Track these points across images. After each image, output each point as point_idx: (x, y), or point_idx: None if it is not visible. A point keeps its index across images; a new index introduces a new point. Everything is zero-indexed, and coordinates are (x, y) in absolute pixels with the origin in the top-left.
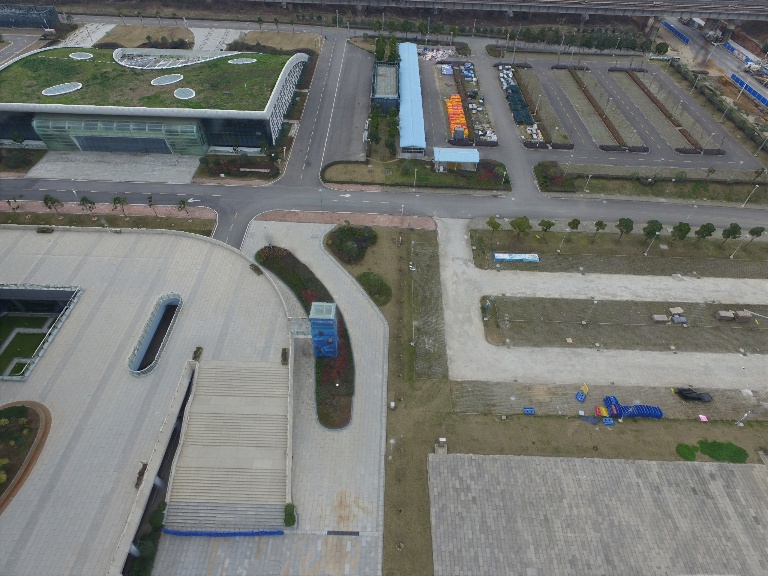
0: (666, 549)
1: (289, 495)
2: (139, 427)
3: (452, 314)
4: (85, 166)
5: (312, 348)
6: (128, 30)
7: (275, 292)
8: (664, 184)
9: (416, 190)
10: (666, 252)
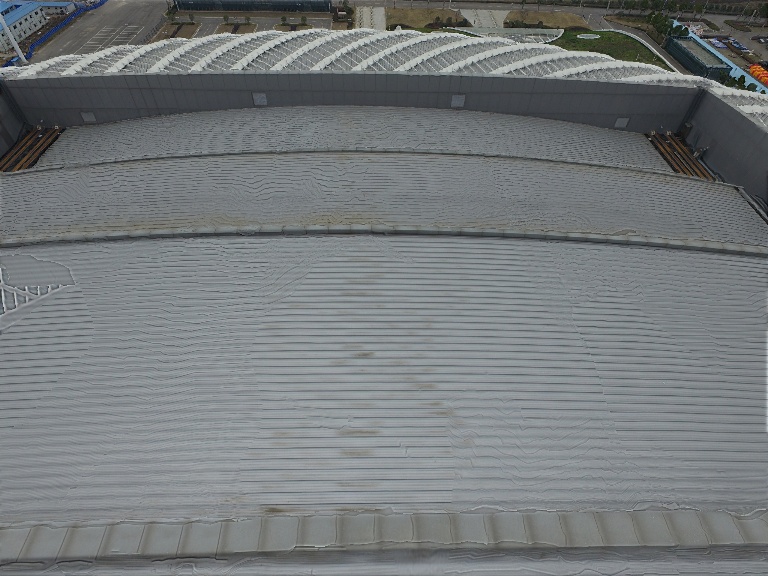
0: None
1: None
2: None
3: None
4: None
5: None
6: (402, 12)
7: None
8: None
9: None
10: None
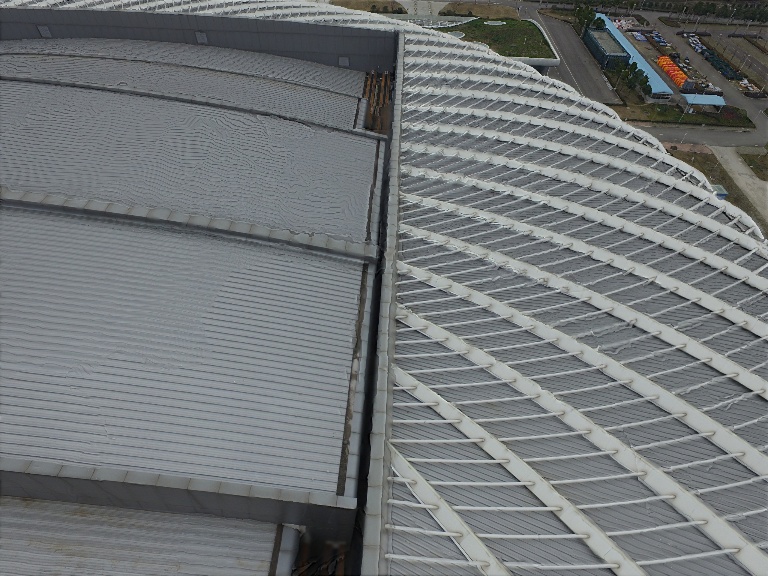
0: None
1: None
2: None
3: (764, 209)
4: None
5: None
6: (345, 1)
7: None
8: None
9: (679, 126)
10: None
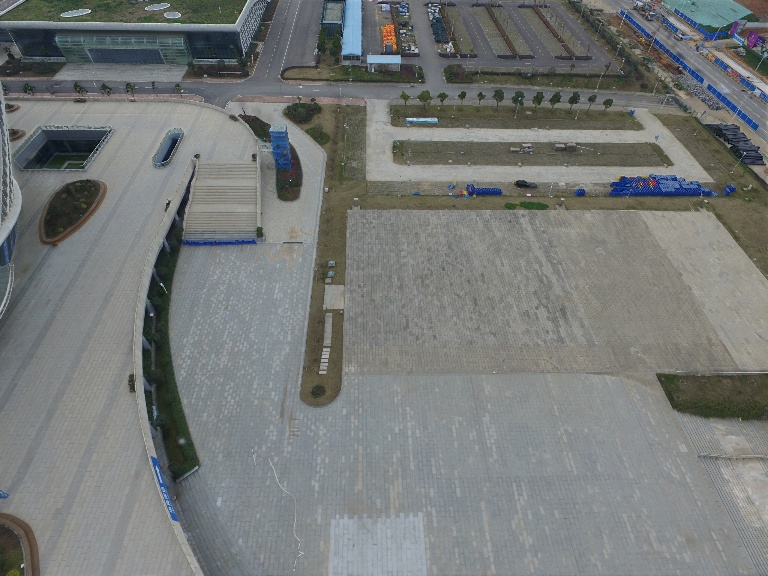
0: (485, 243)
1: (259, 224)
2: (163, 189)
3: (372, 150)
4: (98, 72)
5: (274, 165)
6: None
7: (247, 129)
8: (540, 78)
9: (353, 83)
10: (530, 116)
